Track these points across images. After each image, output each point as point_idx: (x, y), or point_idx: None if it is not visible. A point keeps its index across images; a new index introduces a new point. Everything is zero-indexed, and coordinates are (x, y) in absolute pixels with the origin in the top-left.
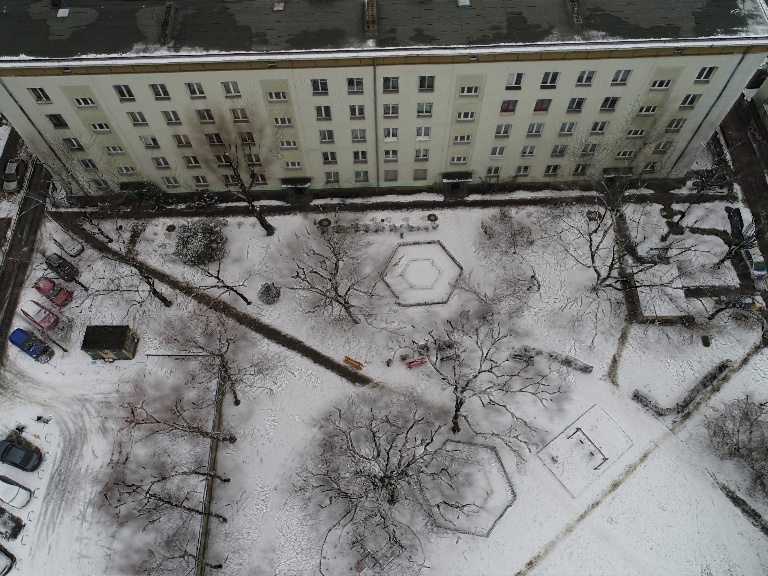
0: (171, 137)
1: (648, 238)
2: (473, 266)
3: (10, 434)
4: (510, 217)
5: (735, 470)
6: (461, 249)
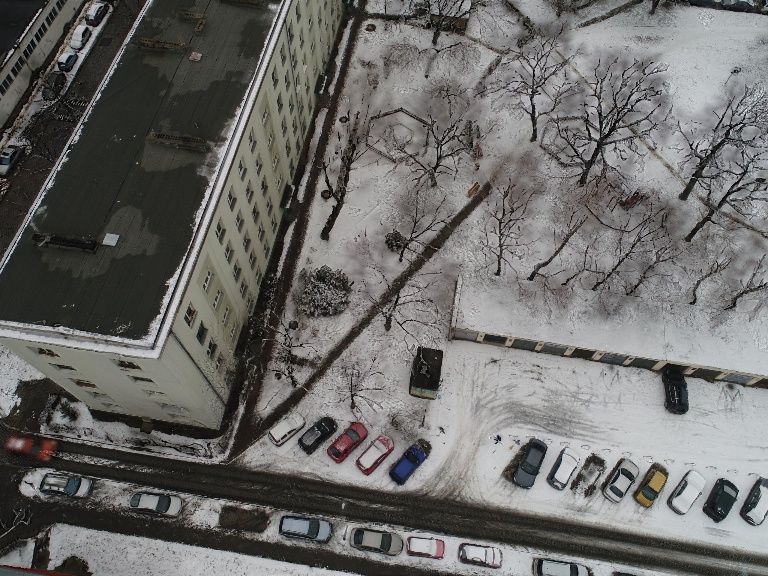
0: (242, 246)
1: (398, 7)
2: (399, 104)
3: (505, 477)
4: (368, 64)
5: (570, 17)
6: (380, 108)
